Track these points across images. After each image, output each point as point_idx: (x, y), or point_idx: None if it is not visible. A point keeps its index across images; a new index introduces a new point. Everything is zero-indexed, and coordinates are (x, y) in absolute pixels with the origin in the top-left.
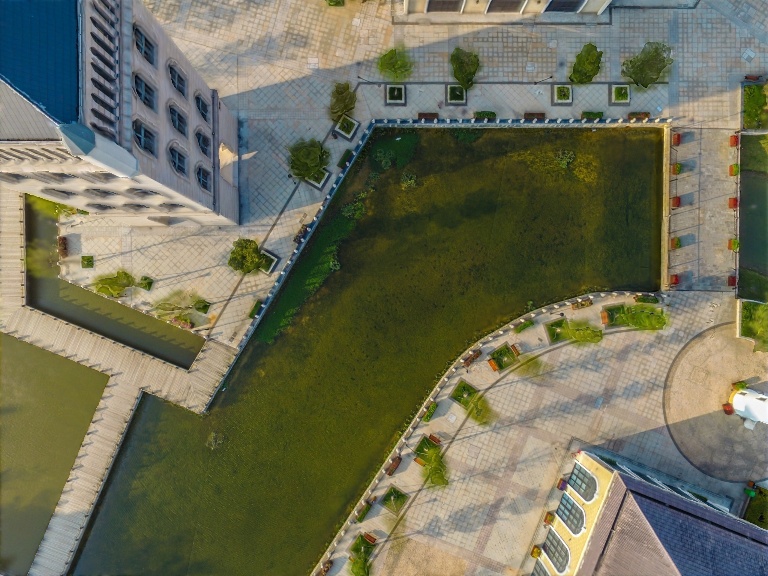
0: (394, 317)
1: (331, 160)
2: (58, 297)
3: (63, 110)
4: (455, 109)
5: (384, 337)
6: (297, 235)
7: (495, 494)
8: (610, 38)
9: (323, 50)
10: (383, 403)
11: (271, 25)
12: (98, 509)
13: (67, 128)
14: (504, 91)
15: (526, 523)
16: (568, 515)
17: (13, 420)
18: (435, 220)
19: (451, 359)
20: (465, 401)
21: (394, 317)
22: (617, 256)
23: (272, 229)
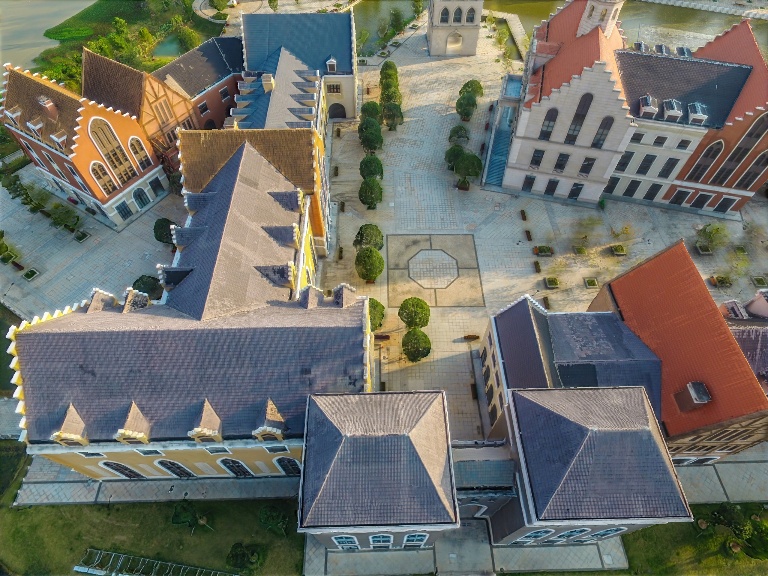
0: None
1: (390, 48)
2: None
3: None
4: None
5: (368, 19)
6: None
7: None
8: None
9: None
10: (368, 7)
11: None
12: None
13: None
14: None
15: None
16: None
17: (505, 3)
18: None
19: None
20: None
21: None
22: None
23: None
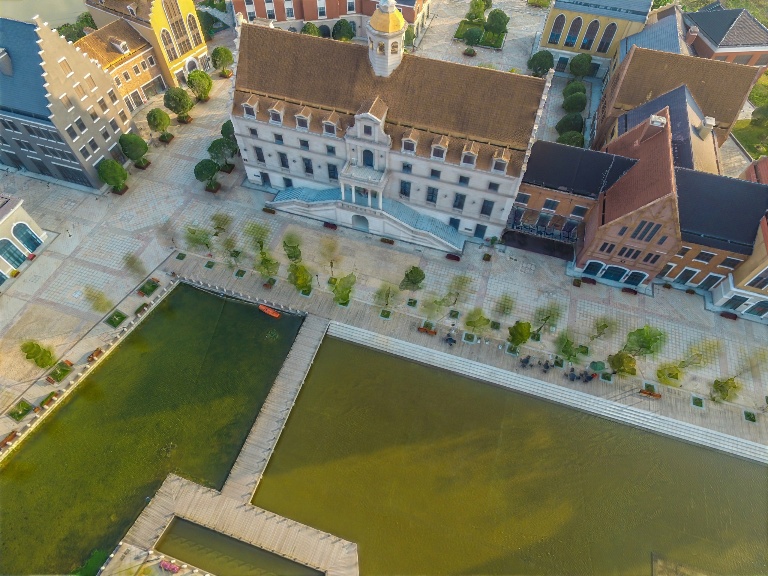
0: None
1: None
2: None
3: None
4: None
5: None
6: None
7: None
8: None
9: None
10: (5, 496)
11: None
12: None
13: None
14: None
15: None
16: None
17: (341, 456)
18: None
19: None
20: None
21: None
22: None
23: None
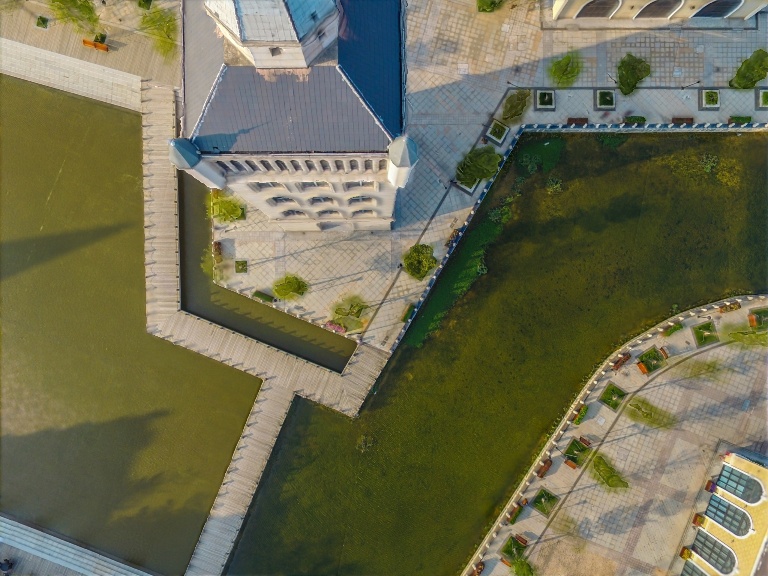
0: (540, 320)
1: None
2: (209, 301)
3: (393, 123)
4: (603, 114)
5: (530, 340)
6: (450, 240)
7: (644, 496)
8: (756, 43)
9: (473, 56)
10: (530, 406)
11: (421, 31)
12: (249, 511)
13: (408, 141)
14: (652, 96)
15: (675, 525)
16: (724, 517)
17: (166, 423)
18: (580, 224)
19: (597, 362)
20: (614, 404)
21: (540, 320)
22: (760, 259)
23: (423, 234)
